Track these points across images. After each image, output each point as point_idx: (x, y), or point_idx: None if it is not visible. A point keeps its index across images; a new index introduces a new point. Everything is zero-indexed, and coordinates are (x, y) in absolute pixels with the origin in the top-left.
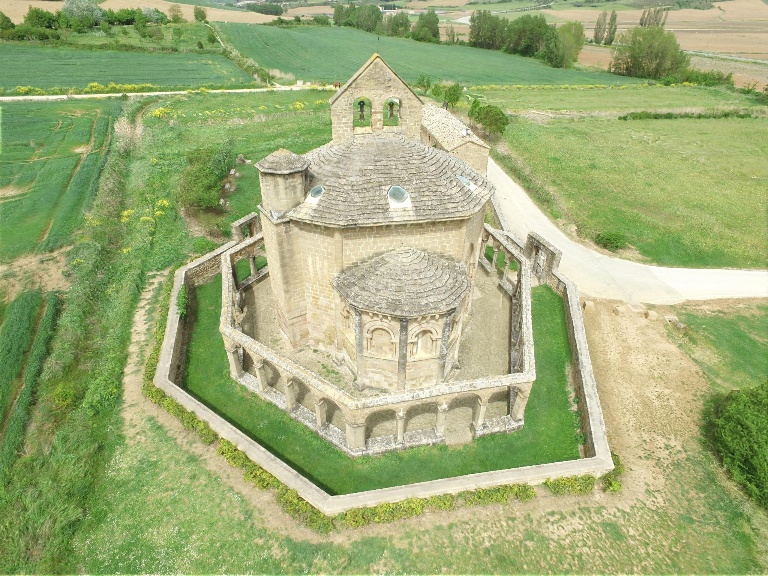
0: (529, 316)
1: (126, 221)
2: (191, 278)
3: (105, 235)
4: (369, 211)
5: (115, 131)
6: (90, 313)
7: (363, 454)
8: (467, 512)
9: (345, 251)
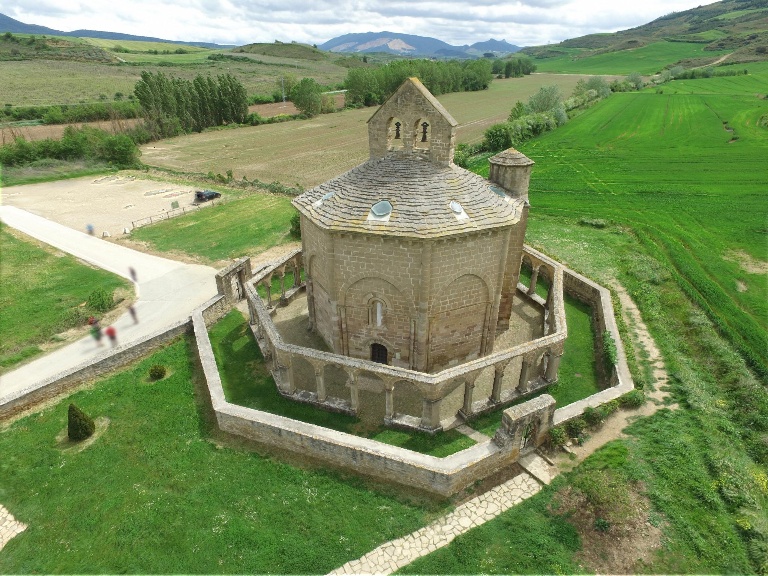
0: None
1: None
2: None
3: None
4: None
5: None
6: (721, 376)
7: None
8: None
9: None
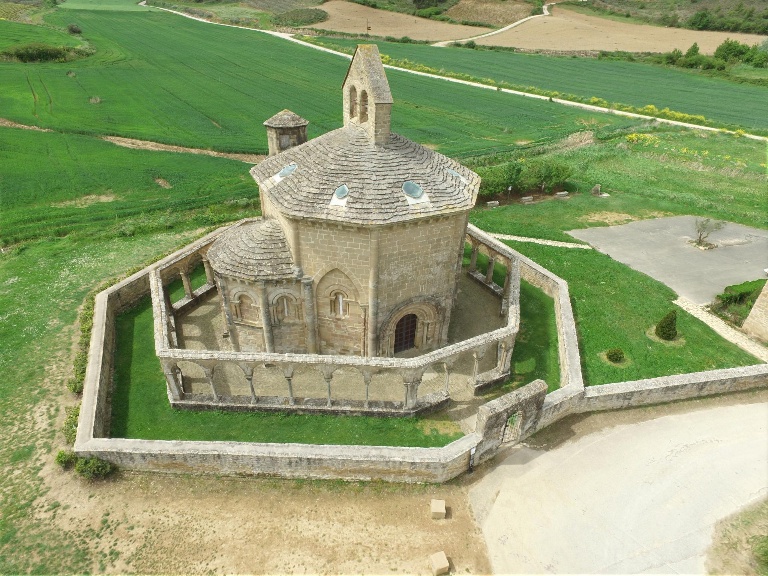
0: (268, 355)
1: None
2: None
3: None
4: (265, 172)
5: (564, 138)
6: None
7: None
8: None
9: (264, 201)
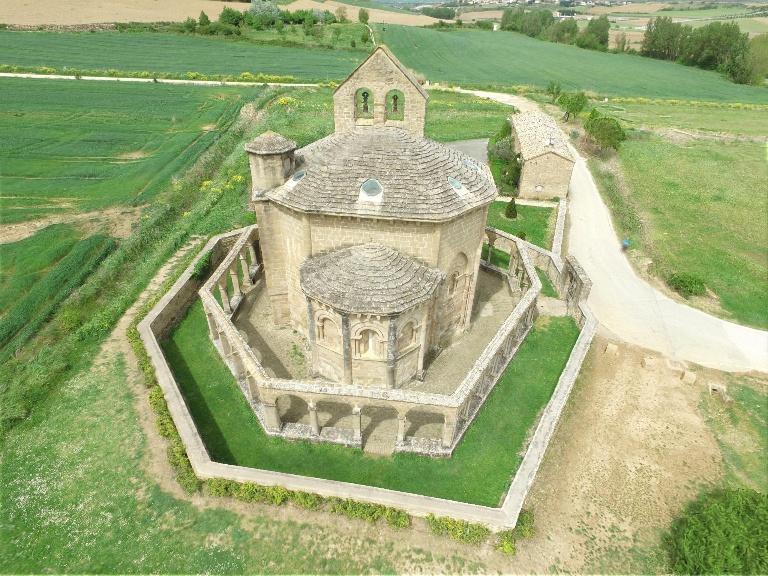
0: (498, 341)
1: (204, 190)
2: (225, 246)
3: (181, 199)
4: (336, 200)
5: (240, 114)
6: (132, 260)
7: (276, 435)
8: (329, 518)
9: (314, 237)
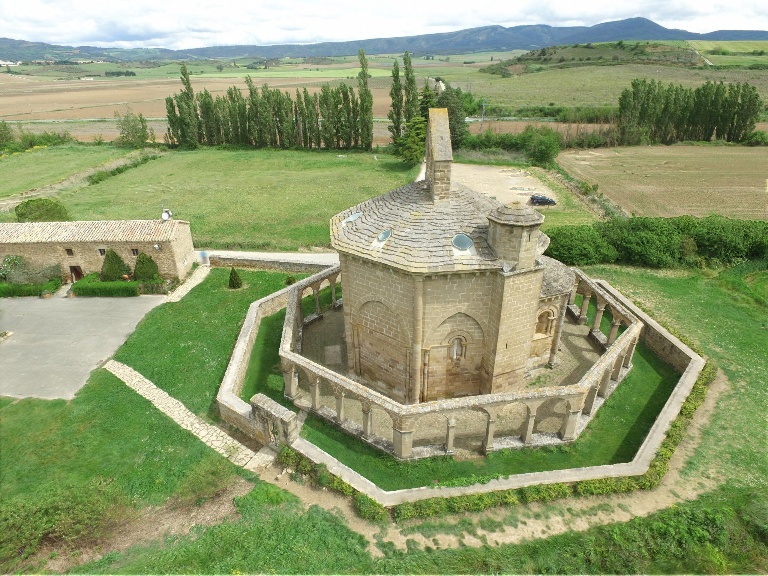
0: None
1: None
2: None
3: None
4: None
5: None
6: None
7: None
8: None
9: None
